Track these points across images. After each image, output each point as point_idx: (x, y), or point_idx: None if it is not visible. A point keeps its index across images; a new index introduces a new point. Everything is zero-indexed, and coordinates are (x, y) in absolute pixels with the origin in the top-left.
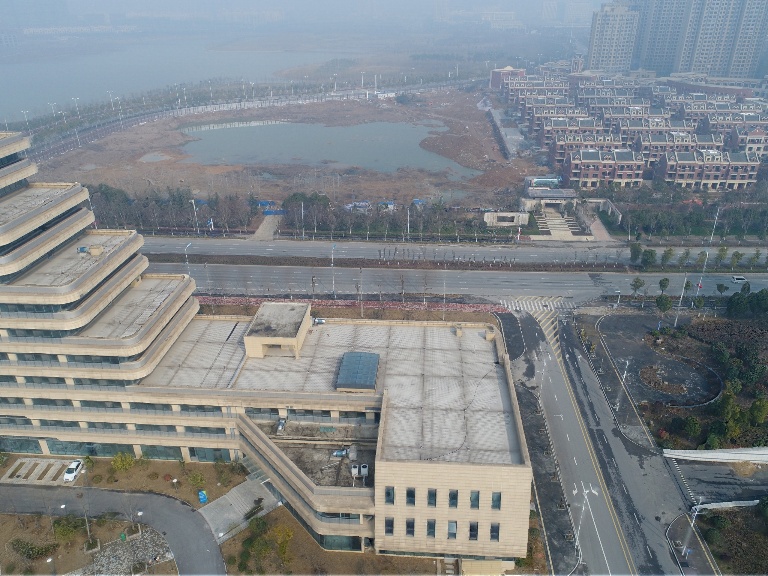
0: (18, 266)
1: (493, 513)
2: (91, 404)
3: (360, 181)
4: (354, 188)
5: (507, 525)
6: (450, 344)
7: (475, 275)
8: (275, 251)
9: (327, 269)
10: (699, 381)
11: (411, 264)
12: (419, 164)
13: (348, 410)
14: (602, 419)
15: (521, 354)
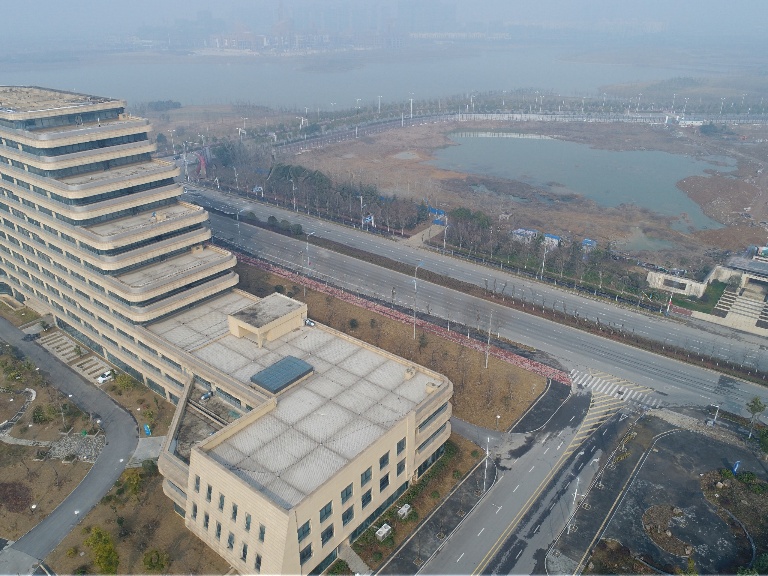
0: (88, 215)
1: (258, 543)
2: (121, 331)
3: (563, 209)
4: (549, 215)
5: (266, 562)
6: (389, 383)
7: (575, 334)
8: (408, 258)
9: (434, 286)
10: (722, 553)
11: (516, 303)
12: (651, 204)
13: (247, 403)
14: (540, 533)
15: (531, 430)
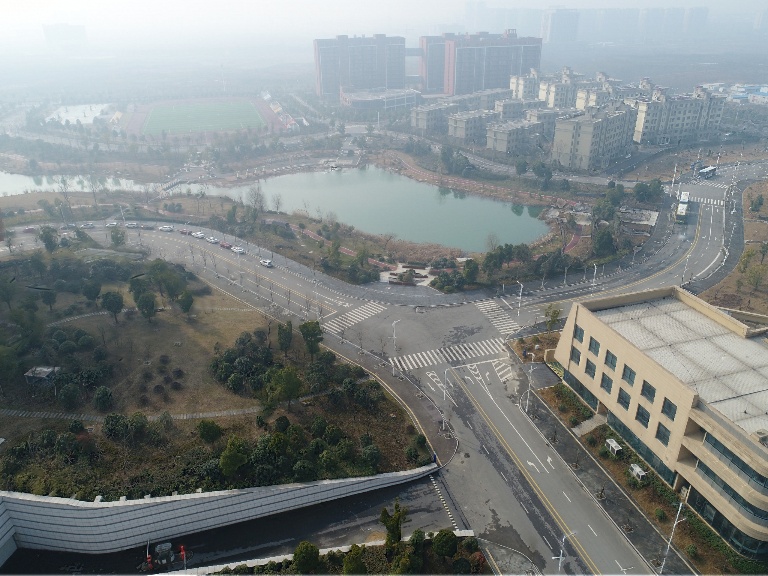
0: None
1: None
2: None
3: None
4: None
5: None
6: None
7: None
8: None
9: None
10: None
11: None
12: None
13: None
14: None
15: None
